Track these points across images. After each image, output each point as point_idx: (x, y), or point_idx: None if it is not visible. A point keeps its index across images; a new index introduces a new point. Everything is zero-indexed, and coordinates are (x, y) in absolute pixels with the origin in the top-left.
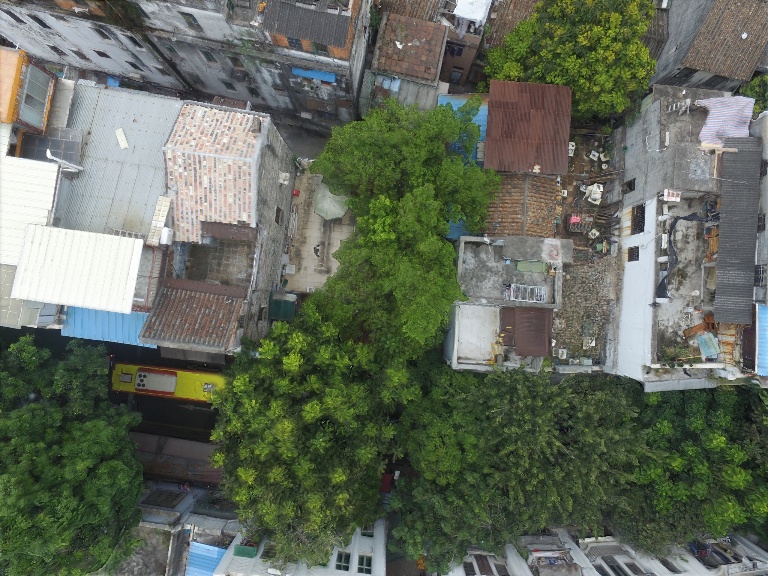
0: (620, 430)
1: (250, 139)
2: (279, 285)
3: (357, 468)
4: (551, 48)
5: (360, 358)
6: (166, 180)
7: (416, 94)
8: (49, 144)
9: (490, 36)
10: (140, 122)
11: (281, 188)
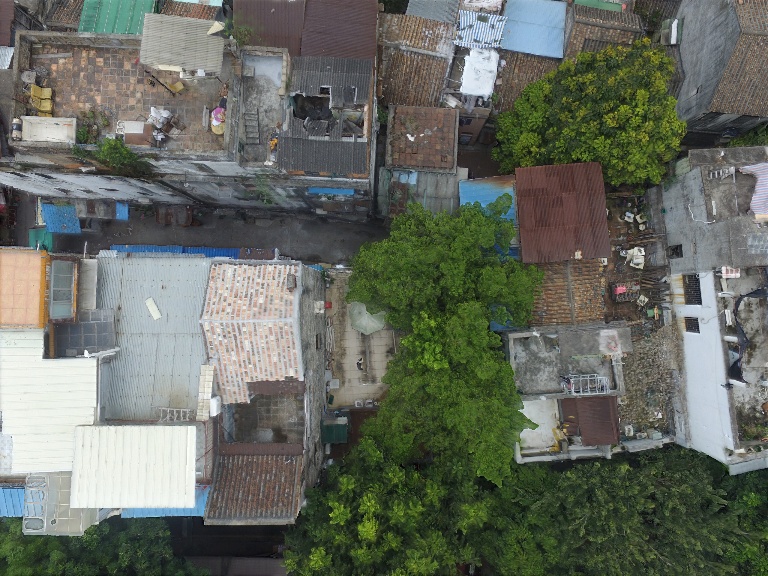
0: (712, 523)
1: (286, 295)
2: (326, 403)
3: None
4: (574, 127)
5: (432, 497)
6: (206, 350)
7: (435, 184)
8: (81, 330)
9: (497, 102)
10: (169, 288)
11: (316, 314)
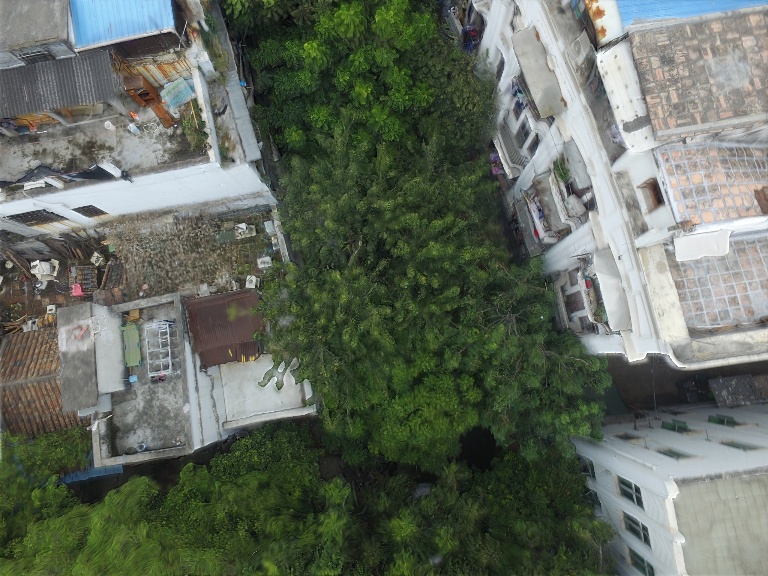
0: None
1: None
2: None
3: (482, 556)
4: None
5: None
6: None
7: None
8: None
9: None
10: None
11: None
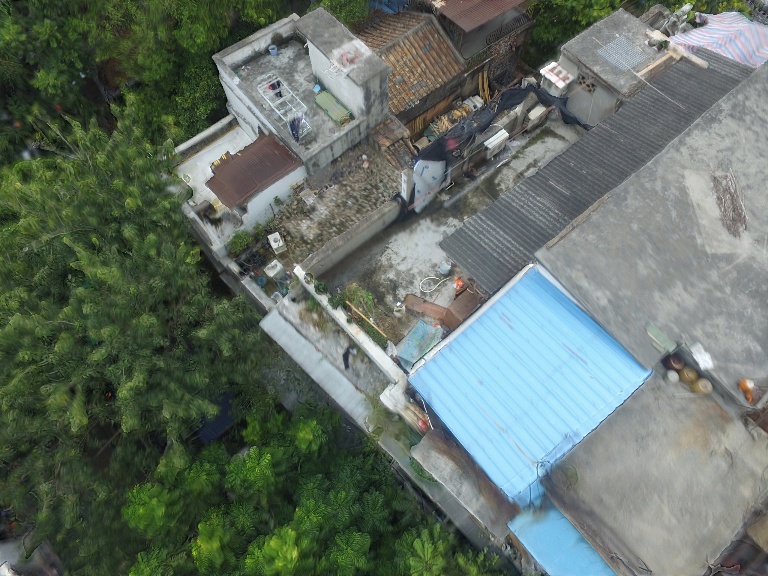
0: None
1: None
2: None
3: None
4: None
5: None
6: None
7: None
8: None
9: None
10: None
11: None
